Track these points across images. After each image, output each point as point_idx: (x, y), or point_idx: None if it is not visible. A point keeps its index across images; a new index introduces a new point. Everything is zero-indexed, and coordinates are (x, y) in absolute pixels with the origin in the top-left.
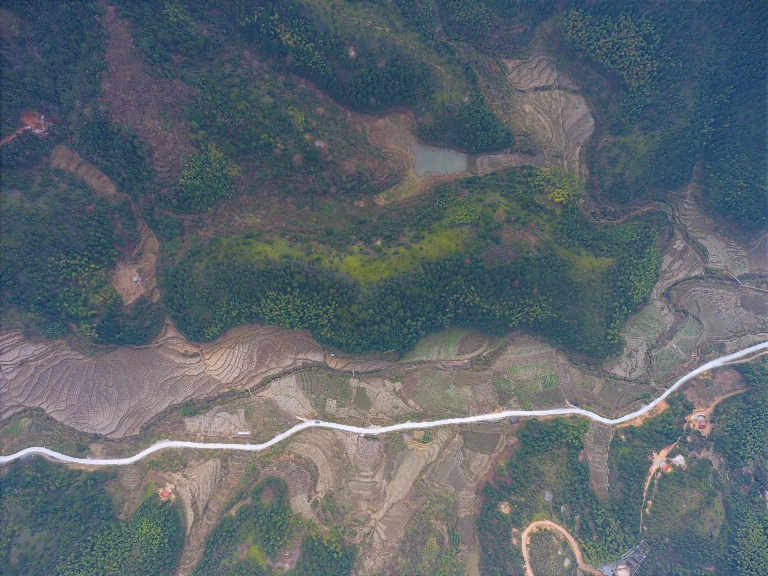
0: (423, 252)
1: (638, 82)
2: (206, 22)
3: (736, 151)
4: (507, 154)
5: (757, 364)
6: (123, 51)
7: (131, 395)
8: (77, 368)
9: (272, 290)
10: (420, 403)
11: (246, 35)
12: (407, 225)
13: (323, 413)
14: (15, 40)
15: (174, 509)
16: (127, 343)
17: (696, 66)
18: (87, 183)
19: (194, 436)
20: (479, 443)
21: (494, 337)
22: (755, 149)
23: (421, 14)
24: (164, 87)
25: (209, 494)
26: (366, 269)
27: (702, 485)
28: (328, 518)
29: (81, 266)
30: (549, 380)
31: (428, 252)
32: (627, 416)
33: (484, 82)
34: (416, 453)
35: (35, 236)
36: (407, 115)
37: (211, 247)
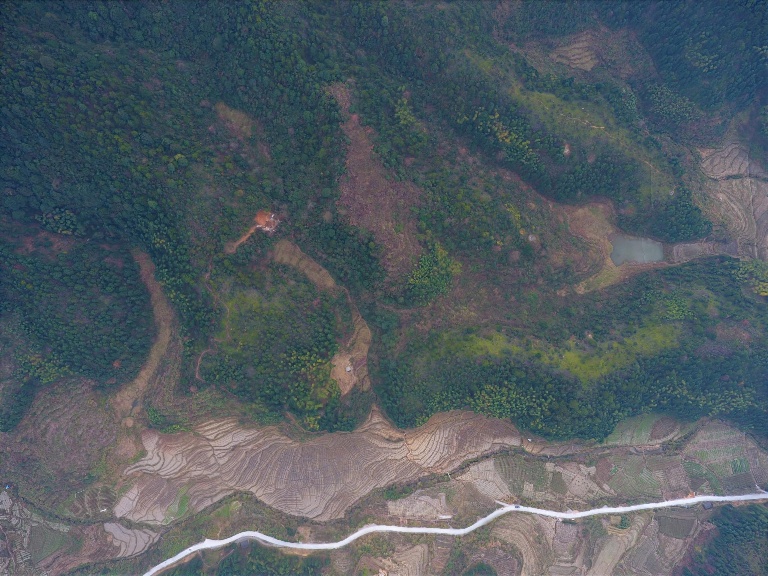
0: (638, 347)
1: None
2: (425, 120)
3: None
4: (702, 243)
5: None
6: (363, 157)
7: (336, 479)
8: (285, 452)
9: (489, 383)
10: (614, 487)
11: (460, 131)
12: (614, 317)
13: (521, 497)
14: (249, 141)
15: None
16: (338, 430)
17: None
18: (308, 277)
19: (398, 520)
20: (674, 528)
21: (687, 423)
22: None
23: (626, 108)
24: (398, 190)
25: None
26: (587, 366)
27: None
28: None
29: (309, 361)
30: (739, 465)
31: (643, 347)
32: None
33: (686, 175)
34: (616, 539)
35: (272, 335)
36: (606, 205)
37: (433, 342)
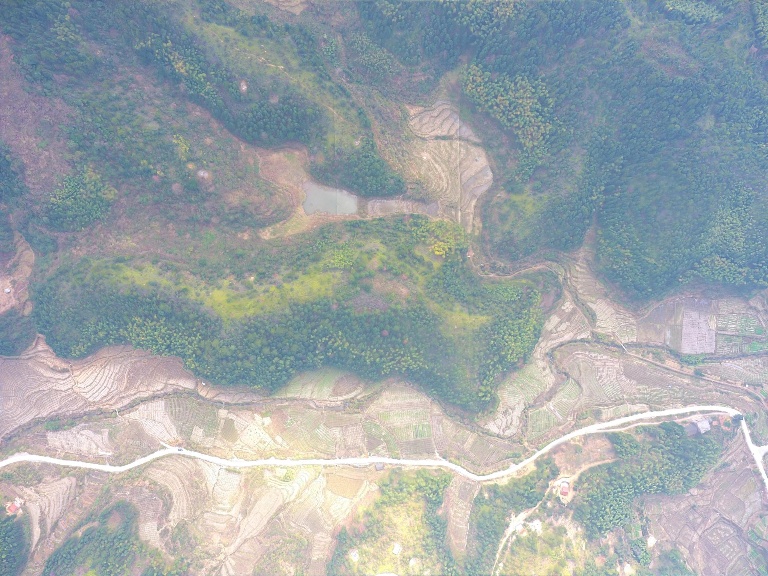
0: (293, 293)
1: (532, 142)
2: (101, 42)
3: (624, 221)
4: (399, 200)
5: (627, 435)
6: (3, 66)
7: None
8: None
9: (138, 316)
10: (287, 440)
11: (142, 58)
12: (285, 263)
13: (188, 441)
14: None
15: (18, 525)
16: None
17: (587, 133)
18: None
19: (55, 452)
20: (341, 486)
21: (368, 382)
22: (642, 221)
23: (322, 54)
24: (43, 105)
25: (60, 512)
26: (231, 305)
27: (553, 553)
28: (176, 548)
29: None
30: (421, 430)
31: (298, 293)
32: (495, 474)
33: (379, 127)
34: (274, 491)
35: None
36: (301, 152)
37: (80, 267)
